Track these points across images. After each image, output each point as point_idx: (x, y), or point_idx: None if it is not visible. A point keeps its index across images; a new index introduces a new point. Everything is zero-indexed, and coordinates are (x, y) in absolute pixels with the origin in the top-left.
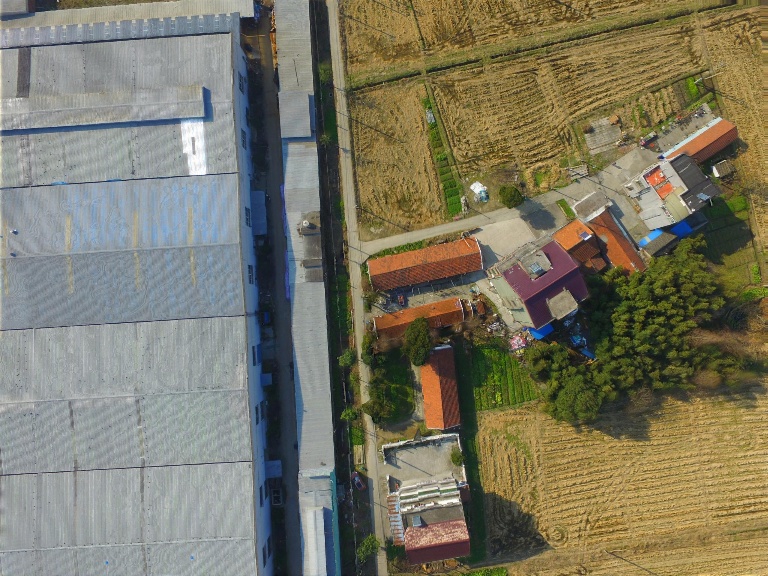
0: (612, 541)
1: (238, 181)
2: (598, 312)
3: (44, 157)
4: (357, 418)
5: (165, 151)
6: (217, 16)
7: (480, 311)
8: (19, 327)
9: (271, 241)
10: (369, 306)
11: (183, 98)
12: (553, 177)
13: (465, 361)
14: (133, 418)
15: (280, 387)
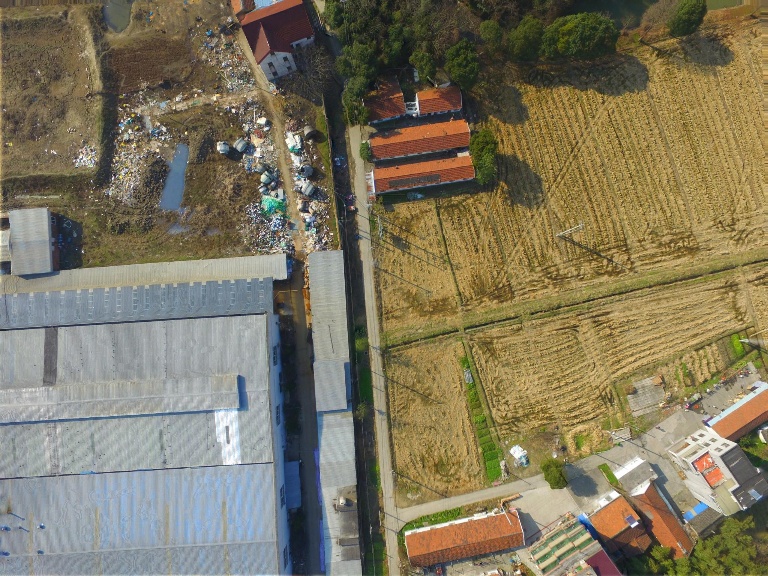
0: None
1: (274, 473)
2: None
3: (72, 445)
4: None
5: (198, 440)
6: (249, 280)
7: None
8: None
9: (305, 507)
10: (406, 575)
11: (217, 389)
12: (595, 440)
13: None
14: None
15: None
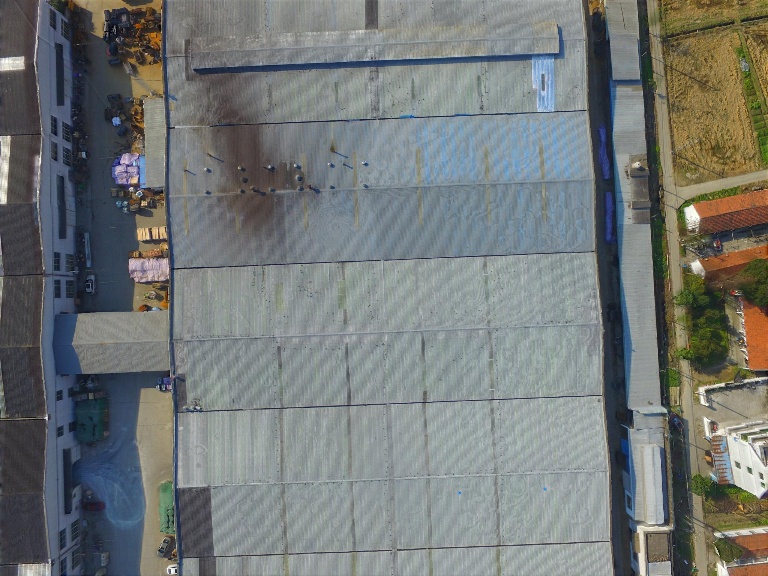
0: None
1: None
2: None
3: (393, 90)
4: (673, 360)
5: (514, 87)
6: None
7: None
8: (367, 259)
9: None
10: (684, 250)
11: (538, 34)
12: None
13: None
14: (485, 350)
15: None
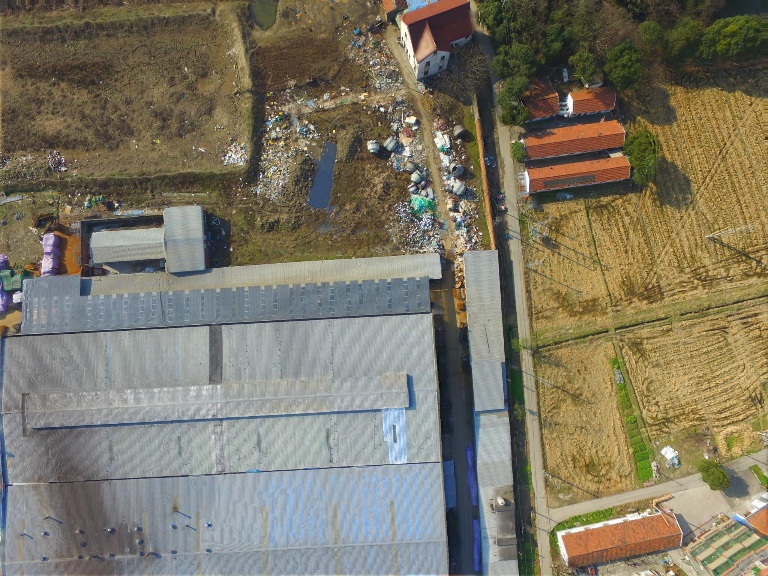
0: None
1: (442, 473)
2: None
3: (238, 444)
4: None
5: (365, 439)
6: (406, 280)
7: None
8: None
9: (456, 507)
10: (558, 575)
11: (387, 388)
12: (746, 442)
13: None
14: None
15: None
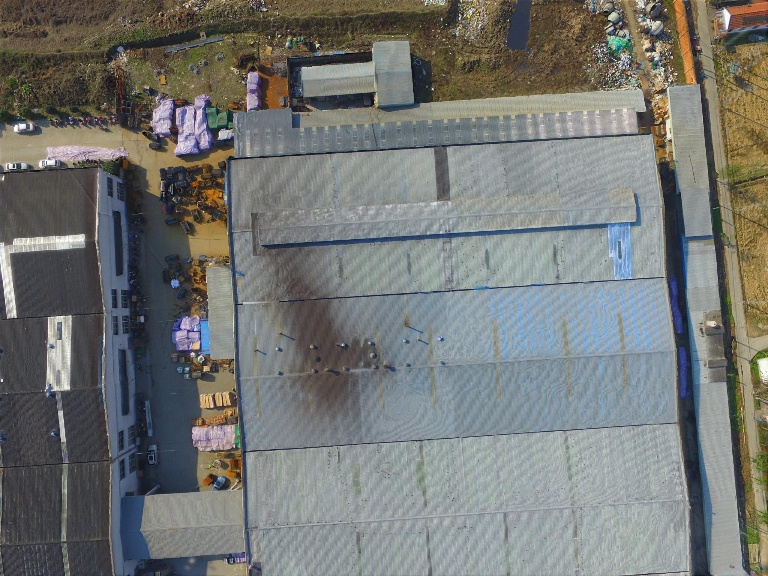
0: None
1: (667, 286)
2: None
3: (467, 261)
4: (751, 516)
5: (591, 255)
6: (613, 111)
7: None
8: (445, 436)
9: None
10: (759, 403)
11: (615, 203)
12: None
13: None
14: (569, 530)
15: None
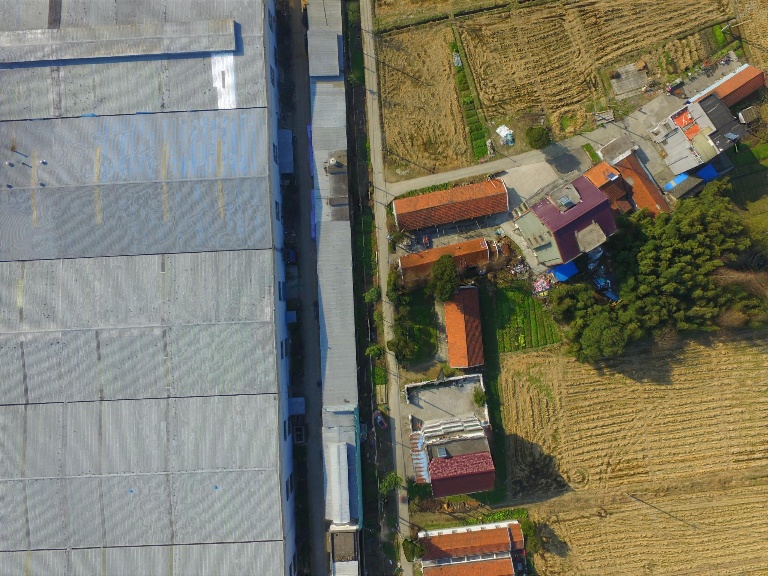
0: (633, 484)
1: (267, 115)
2: (624, 251)
3: (74, 89)
4: (380, 358)
5: (195, 84)
6: None
7: (505, 252)
8: (47, 257)
9: (297, 181)
10: (394, 247)
11: (214, 31)
12: (579, 122)
13: (489, 303)
14: (159, 348)
15: (304, 326)
